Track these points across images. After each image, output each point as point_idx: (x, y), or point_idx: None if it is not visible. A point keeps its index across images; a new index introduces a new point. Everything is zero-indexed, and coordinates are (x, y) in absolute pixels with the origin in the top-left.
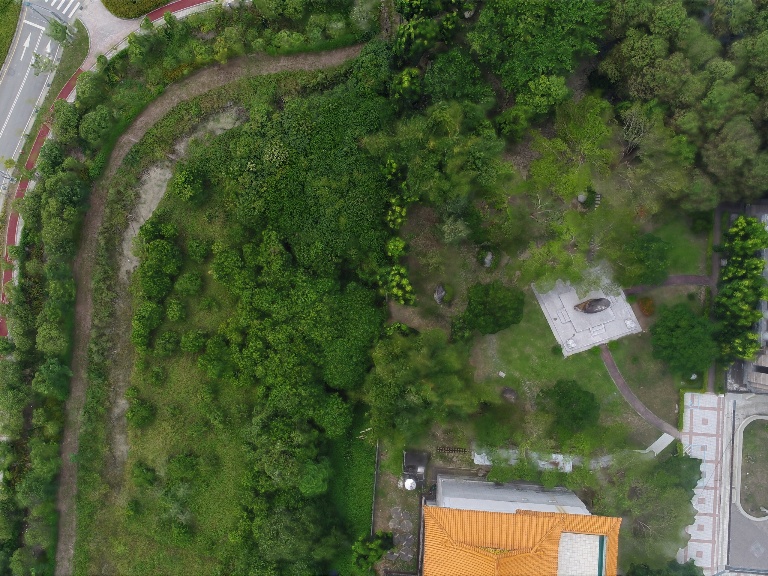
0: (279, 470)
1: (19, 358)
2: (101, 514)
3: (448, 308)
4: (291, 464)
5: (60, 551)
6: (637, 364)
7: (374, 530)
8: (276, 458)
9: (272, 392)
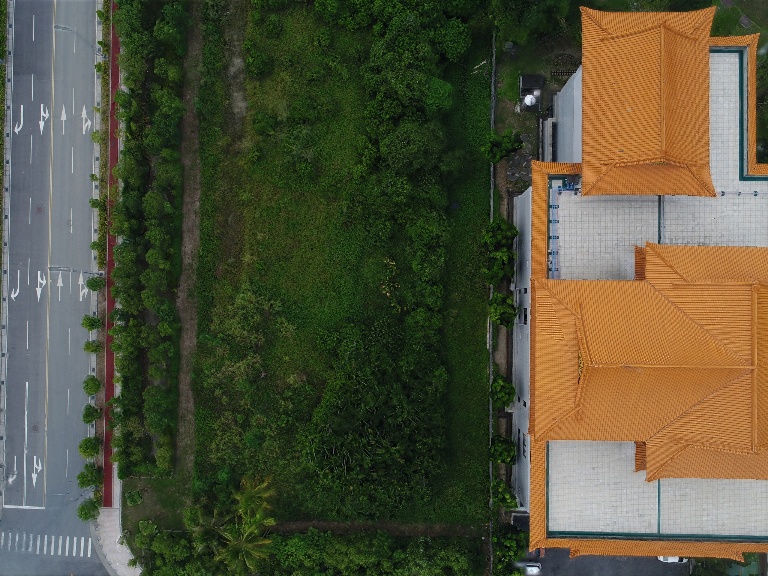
0: (407, 81)
1: (140, 6)
2: (224, 167)
3: None
4: (419, 74)
5: (186, 204)
6: None
7: None
8: (402, 73)
9: (391, 21)
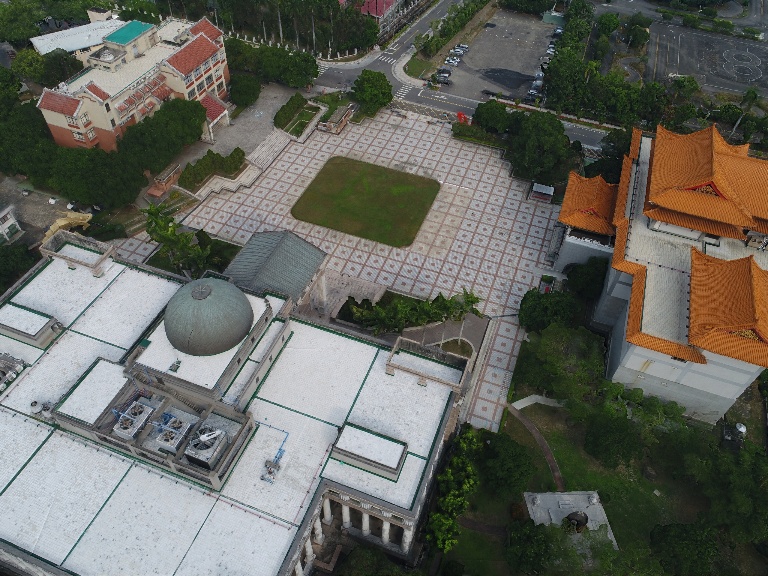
0: None
1: None
2: None
3: (711, 572)
4: None
5: None
6: None
7: (764, 406)
8: None
9: None
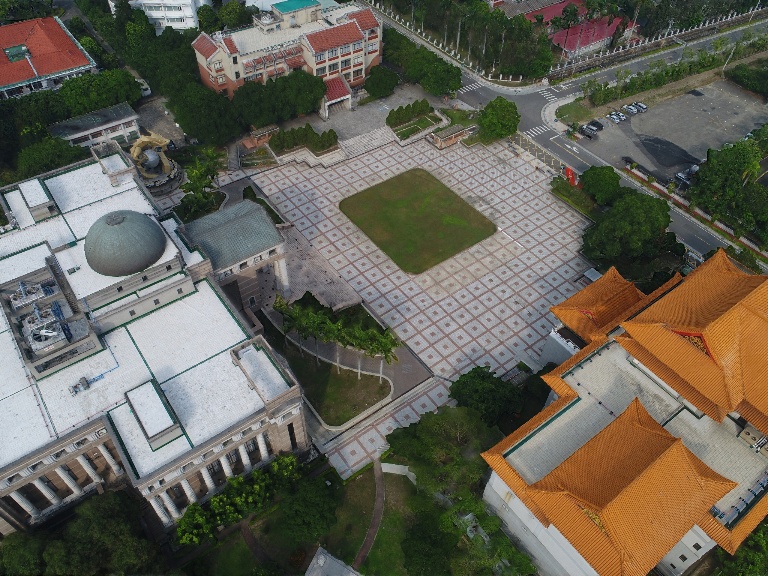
0: None
1: None
2: None
3: None
4: None
5: None
6: (349, 530)
7: None
8: None
9: None
